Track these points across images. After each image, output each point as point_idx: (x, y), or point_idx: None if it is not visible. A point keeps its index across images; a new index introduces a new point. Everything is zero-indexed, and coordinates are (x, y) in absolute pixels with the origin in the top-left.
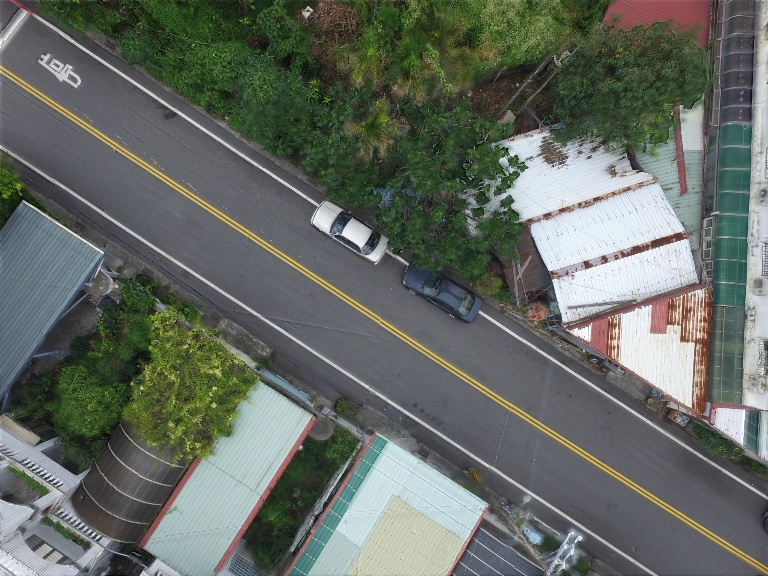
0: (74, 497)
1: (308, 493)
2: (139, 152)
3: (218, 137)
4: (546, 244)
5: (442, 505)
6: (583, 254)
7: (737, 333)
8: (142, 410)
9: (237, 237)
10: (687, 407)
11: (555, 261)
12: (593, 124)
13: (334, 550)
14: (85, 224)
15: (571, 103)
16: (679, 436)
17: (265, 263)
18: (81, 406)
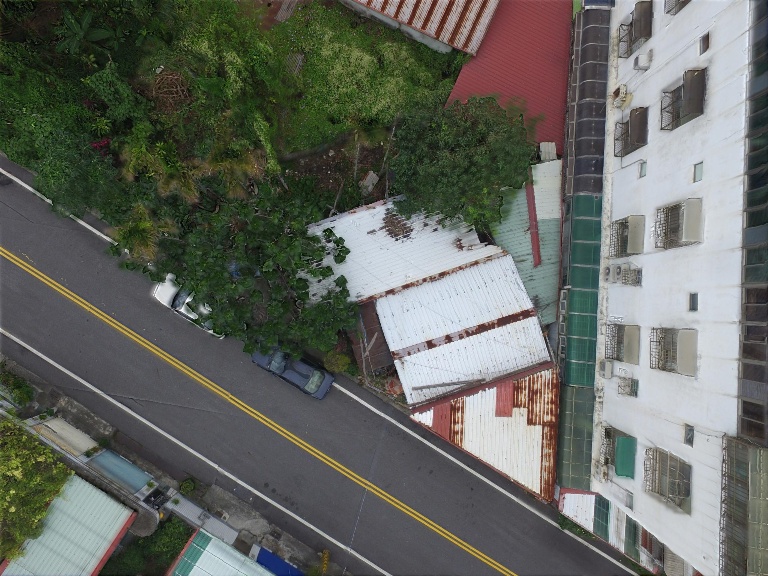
0: None
1: None
2: None
3: None
4: (390, 321)
5: None
6: (427, 333)
7: (586, 415)
8: None
9: (77, 310)
10: (535, 493)
11: (398, 340)
12: (426, 201)
13: None
14: None
15: (402, 179)
16: (545, 511)
17: (107, 337)
18: None
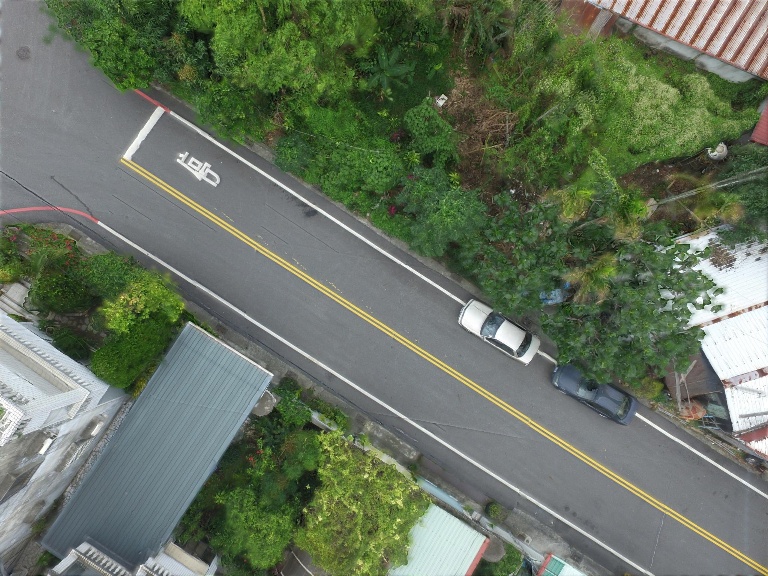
0: None
1: None
2: (280, 252)
3: (359, 234)
4: (714, 350)
5: None
6: (755, 361)
7: None
8: (321, 541)
9: (382, 338)
10: None
11: (726, 369)
12: None
13: None
14: (227, 326)
15: (752, 212)
16: None
17: (410, 364)
18: (259, 539)
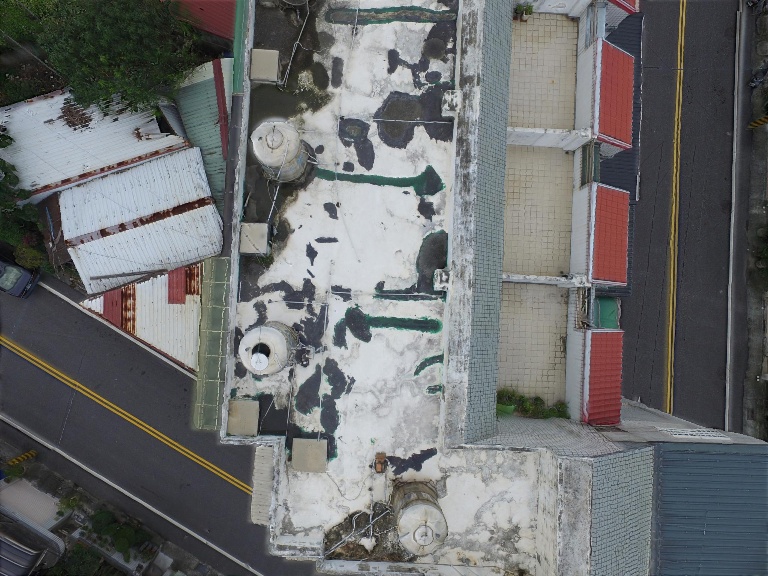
0: None
1: None
2: None
3: None
4: (70, 212)
5: None
6: (103, 222)
7: None
8: None
9: None
10: None
11: (73, 229)
12: None
13: None
14: None
15: None
16: None
17: None
18: None
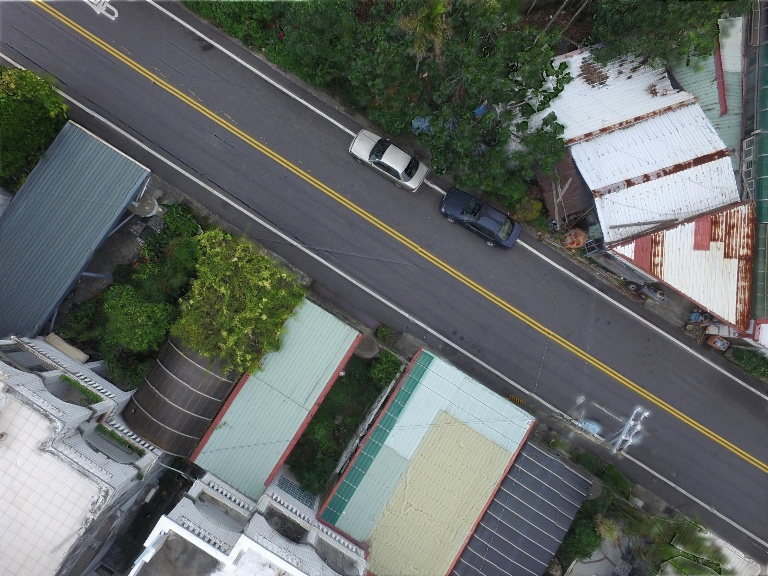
0: (125, 412)
1: (350, 418)
2: (177, 84)
3: (255, 68)
4: (587, 164)
5: (489, 420)
6: (625, 173)
7: None
8: (192, 324)
9: (275, 167)
10: (731, 324)
11: (597, 180)
12: (636, 38)
13: (383, 464)
14: None
15: (614, 17)
16: (718, 362)
17: (303, 193)
18: (132, 320)
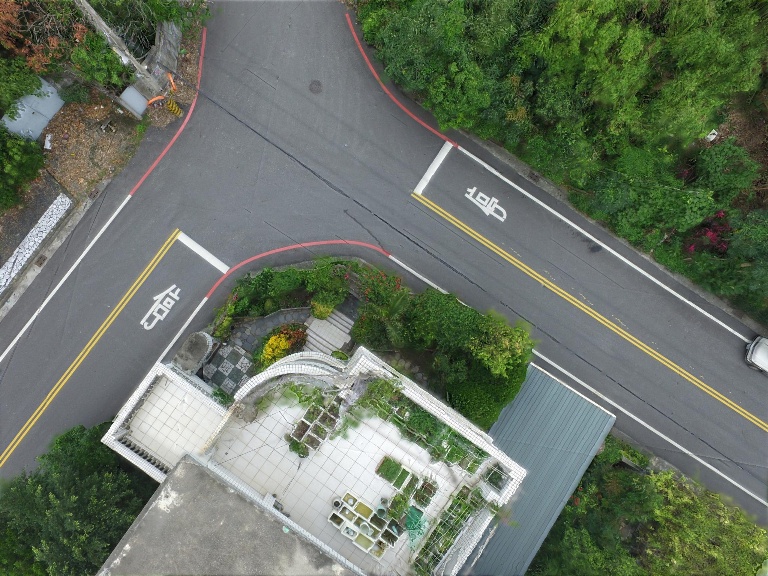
0: None
1: None
2: (567, 287)
3: (643, 270)
4: None
5: None
6: None
7: None
8: None
9: (668, 373)
10: None
11: None
12: None
13: None
14: None
15: None
16: None
17: (695, 399)
18: None
